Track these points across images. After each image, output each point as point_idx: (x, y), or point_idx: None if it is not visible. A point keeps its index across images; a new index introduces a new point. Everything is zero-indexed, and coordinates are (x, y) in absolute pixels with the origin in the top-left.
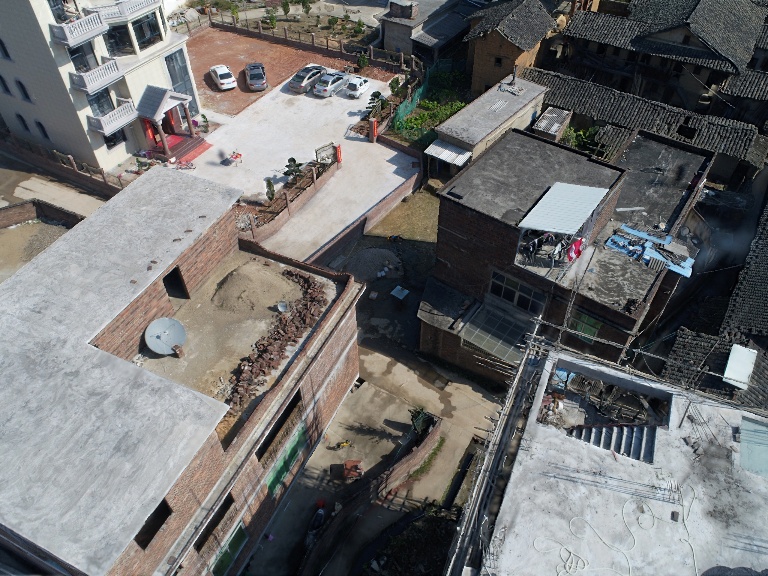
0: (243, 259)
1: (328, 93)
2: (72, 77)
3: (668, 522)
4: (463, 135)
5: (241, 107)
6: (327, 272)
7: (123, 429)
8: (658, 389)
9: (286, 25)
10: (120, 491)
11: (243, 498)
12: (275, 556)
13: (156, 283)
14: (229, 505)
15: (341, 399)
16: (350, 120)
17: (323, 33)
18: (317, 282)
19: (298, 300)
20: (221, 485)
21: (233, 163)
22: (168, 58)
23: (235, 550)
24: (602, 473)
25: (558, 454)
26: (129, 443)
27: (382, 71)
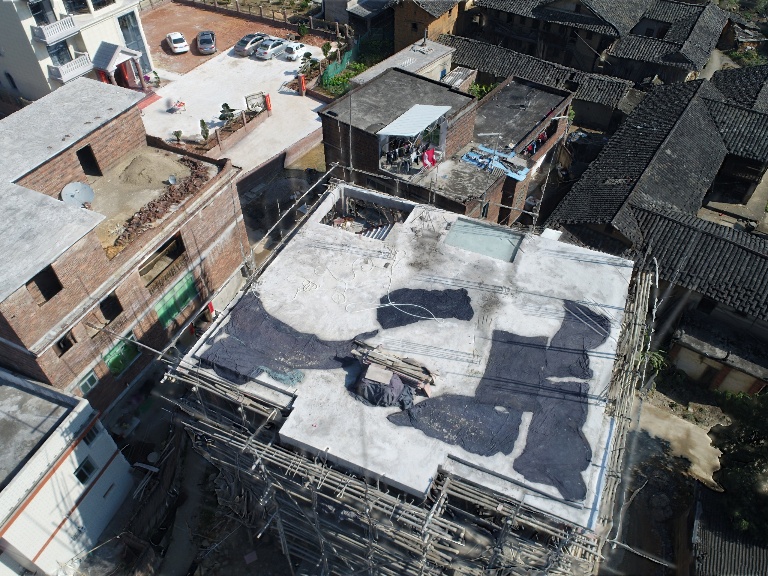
0: (149, 151)
1: (268, 56)
2: (33, 30)
3: (381, 268)
4: None
5: (191, 67)
6: None
7: (28, 227)
8: (407, 203)
9: (241, 1)
10: (20, 258)
11: (132, 311)
12: (175, 388)
13: (70, 154)
14: (119, 312)
15: (233, 270)
16: (285, 78)
17: (273, 8)
18: (203, 165)
19: (186, 177)
20: (107, 286)
21: (178, 111)
22: (121, 19)
23: (131, 360)
24: (348, 245)
25: (322, 236)
26: (31, 234)
27: (320, 39)
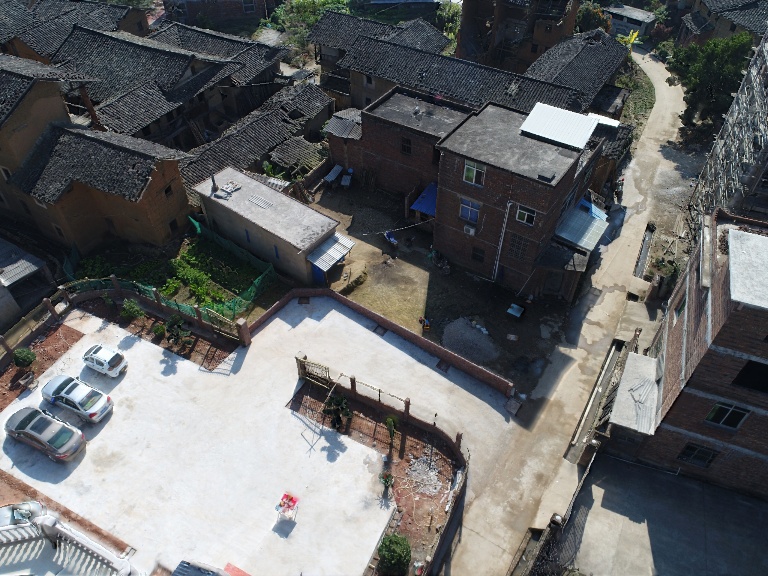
0: None
1: None
2: None
3: None
4: (318, 230)
5: None
6: (716, 225)
7: None
8: None
9: None
10: None
11: None
12: None
13: None
14: None
15: None
16: (187, 371)
17: None
18: None
19: None
20: None
21: None
22: None
23: None
24: None
25: None
26: None
27: (46, 341)
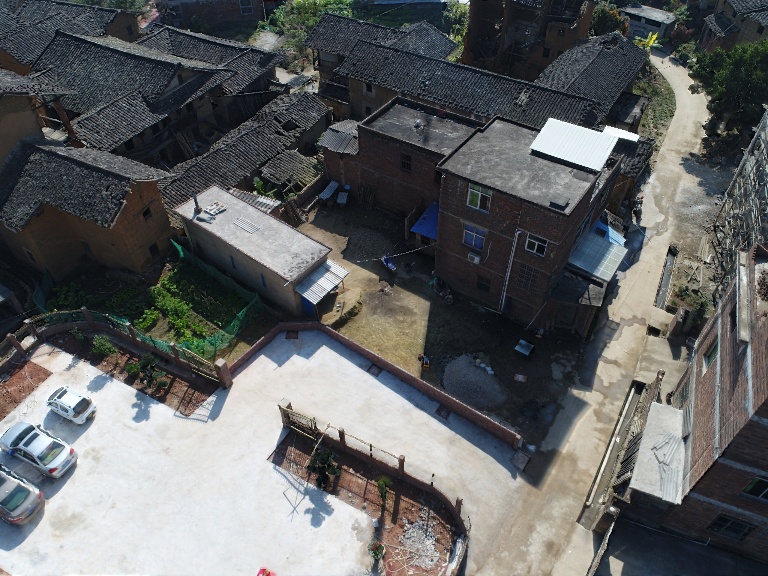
0: None
1: None
2: None
3: None
4: (308, 258)
5: None
6: (754, 265)
7: None
8: None
9: None
10: None
11: None
12: None
13: None
14: None
15: None
16: (161, 417)
17: None
18: (767, 272)
19: None
20: None
21: None
22: None
23: None
24: None
25: None
26: None
27: (10, 380)
